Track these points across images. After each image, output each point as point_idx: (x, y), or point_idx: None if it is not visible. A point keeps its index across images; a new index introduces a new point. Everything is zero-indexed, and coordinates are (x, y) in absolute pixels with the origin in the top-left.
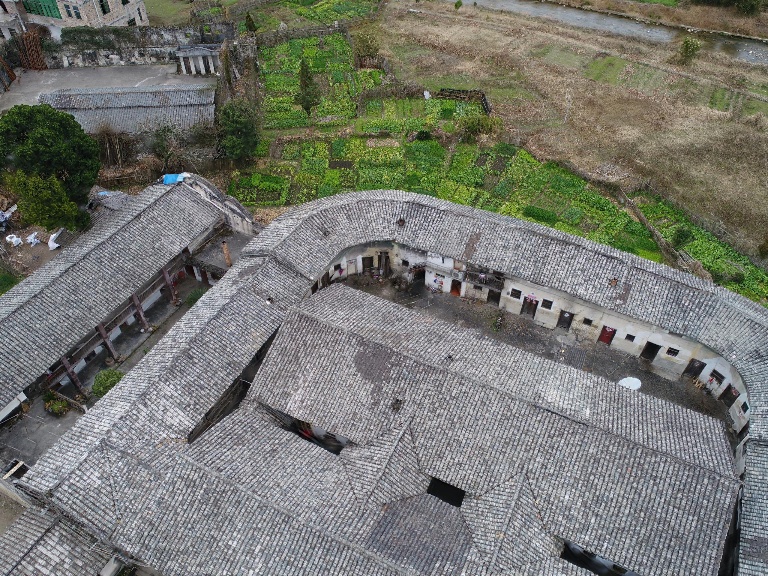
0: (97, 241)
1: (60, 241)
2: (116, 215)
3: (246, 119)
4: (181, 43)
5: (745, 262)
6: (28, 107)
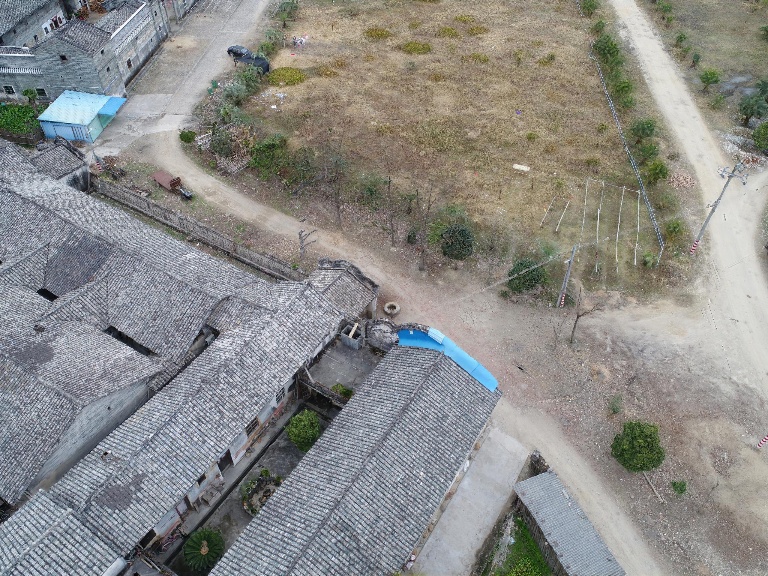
0: (317, 569)
1: None
2: None
3: None
4: None
5: None
6: None
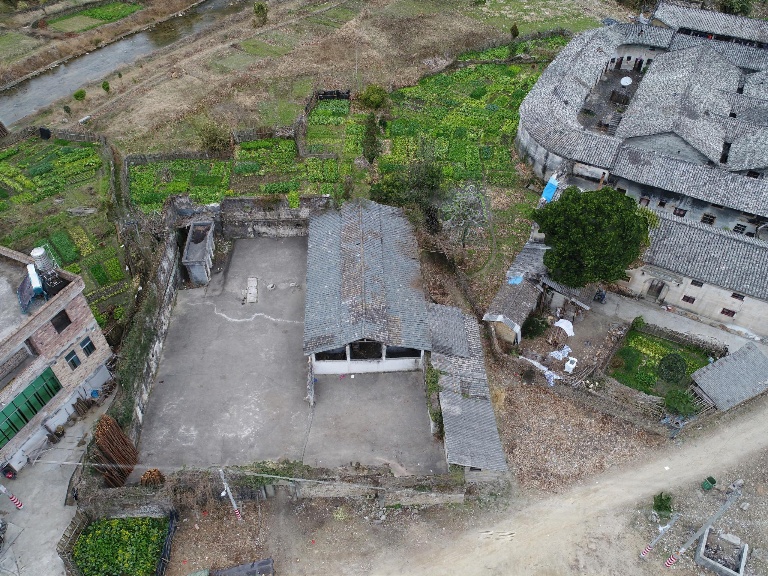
0: None
1: (588, 302)
2: None
3: None
4: (171, 261)
5: None
6: (587, 194)
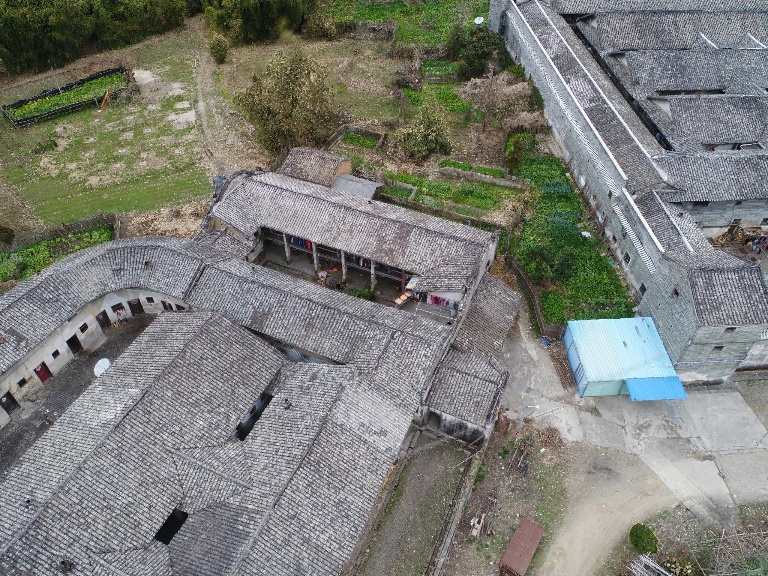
0: None
1: None
2: None
3: None
4: None
5: (6, 256)
6: None
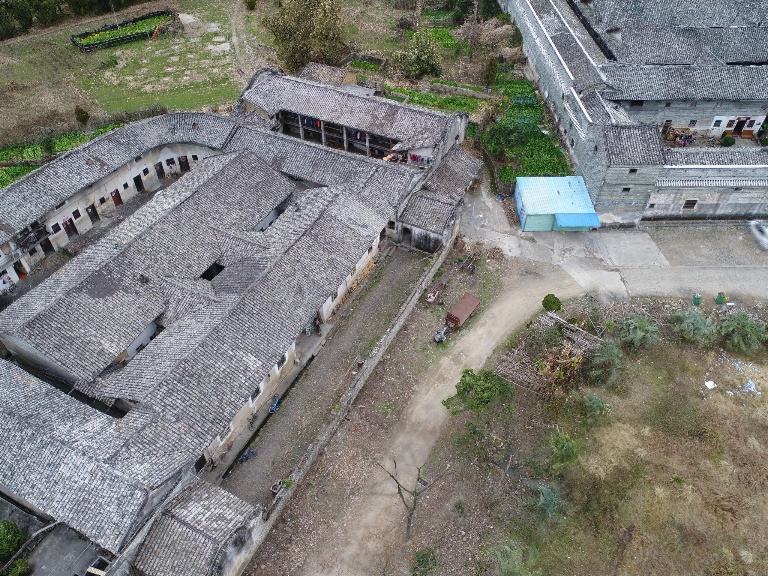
0: None
1: None
2: None
3: None
4: None
5: None
6: None
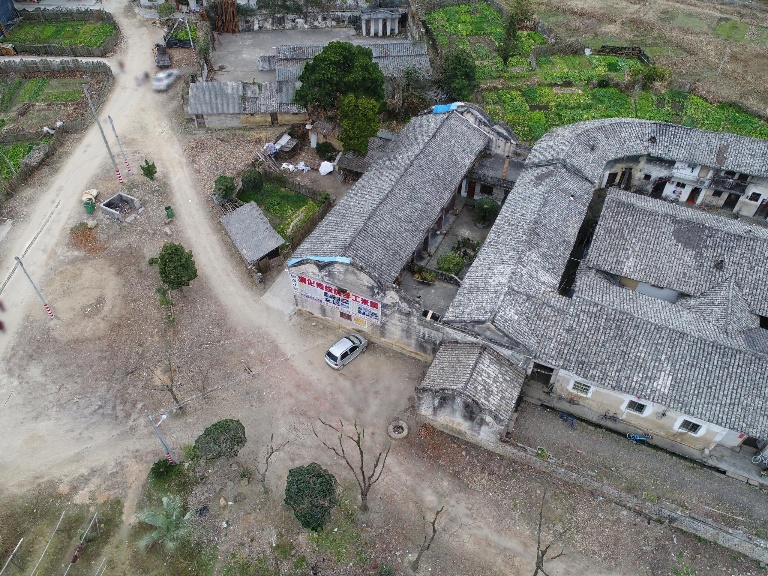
0: (409, 154)
1: (342, 164)
2: (403, 138)
3: (474, 64)
4: (361, 8)
5: None
6: None
